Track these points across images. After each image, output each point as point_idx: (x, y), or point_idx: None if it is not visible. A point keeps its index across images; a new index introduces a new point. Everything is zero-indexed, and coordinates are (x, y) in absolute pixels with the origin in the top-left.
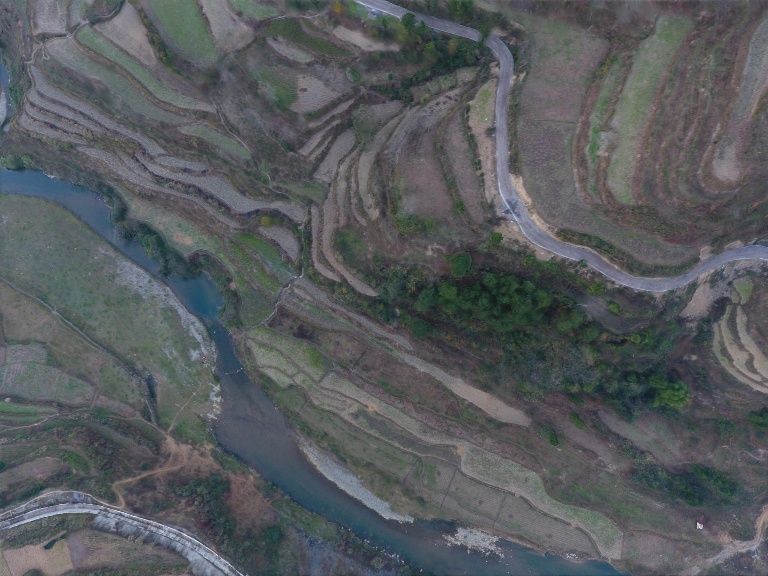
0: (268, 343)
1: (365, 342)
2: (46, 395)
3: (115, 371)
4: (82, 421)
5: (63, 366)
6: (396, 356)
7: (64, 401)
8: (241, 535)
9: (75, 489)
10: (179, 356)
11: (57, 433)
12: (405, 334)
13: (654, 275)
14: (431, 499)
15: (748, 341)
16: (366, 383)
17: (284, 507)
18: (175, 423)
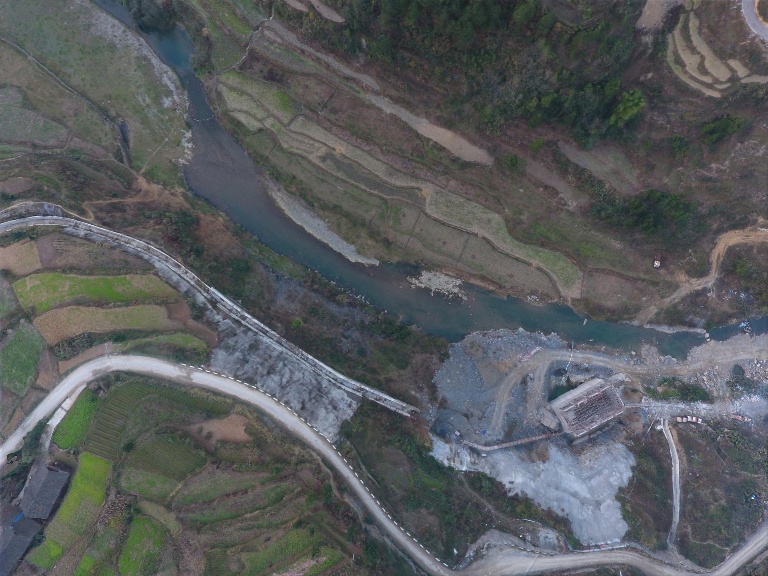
0: (239, 87)
1: (333, 84)
2: (21, 136)
3: (89, 115)
4: (55, 156)
5: (38, 110)
6: (363, 98)
7: (38, 142)
8: (208, 259)
9: (45, 200)
10: (152, 103)
11: (30, 161)
12: (372, 72)
13: None
14: (396, 240)
15: (700, 43)
16: (334, 126)
17: (252, 246)
18: (147, 167)
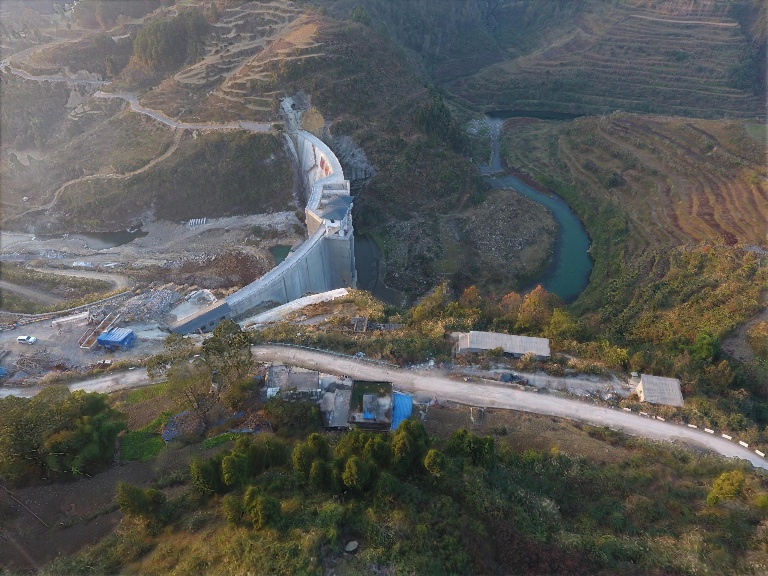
0: None
1: None
2: None
3: None
4: None
5: None
6: None
7: None
8: None
9: None
10: None
11: None
12: None
13: (38, 72)
14: None
15: None
16: None
17: None
18: None
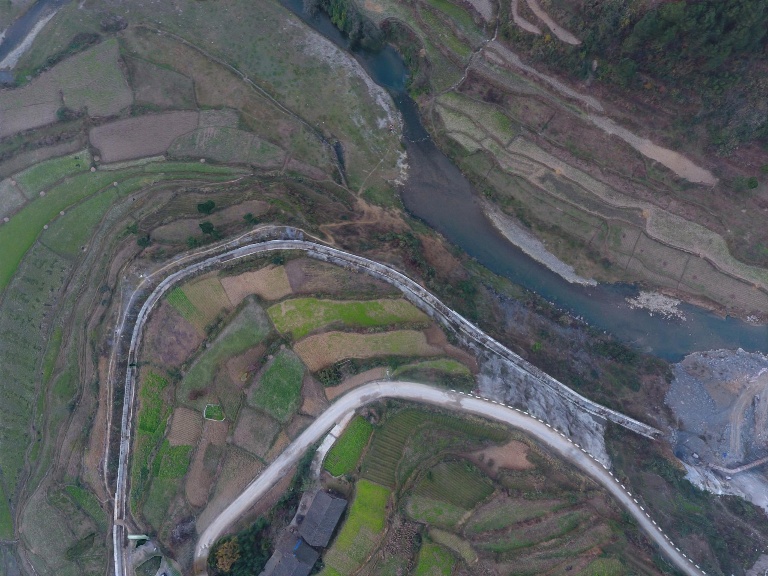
0: (457, 108)
1: (554, 105)
2: (238, 158)
3: (305, 136)
4: (278, 178)
5: (254, 131)
6: (585, 119)
7: (256, 164)
8: (440, 282)
9: (287, 224)
10: (367, 124)
11: (259, 183)
12: (597, 93)
13: None
14: (616, 260)
15: None
16: (554, 147)
17: (473, 267)
18: (364, 188)
